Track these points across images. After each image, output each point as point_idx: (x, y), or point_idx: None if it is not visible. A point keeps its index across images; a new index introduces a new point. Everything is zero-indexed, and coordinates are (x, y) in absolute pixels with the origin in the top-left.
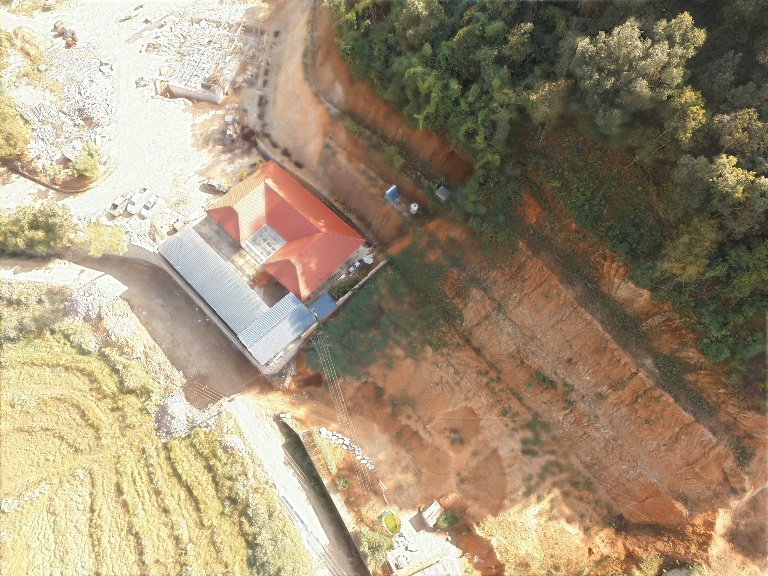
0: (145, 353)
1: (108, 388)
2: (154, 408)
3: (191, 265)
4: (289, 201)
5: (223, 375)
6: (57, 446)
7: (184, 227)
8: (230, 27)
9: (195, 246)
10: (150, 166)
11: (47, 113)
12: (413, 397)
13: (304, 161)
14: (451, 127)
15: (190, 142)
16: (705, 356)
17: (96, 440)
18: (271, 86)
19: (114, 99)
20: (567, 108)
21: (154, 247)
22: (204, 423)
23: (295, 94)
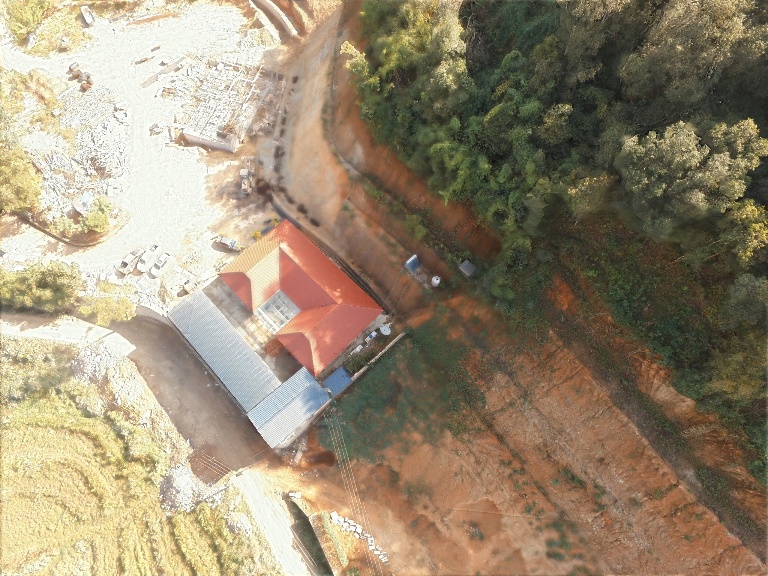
0: (151, 419)
1: (113, 455)
2: (159, 479)
3: (201, 333)
4: (304, 268)
5: (231, 446)
6: (59, 514)
7: (195, 291)
8: (248, 70)
9: (205, 312)
10: (162, 220)
11: (59, 161)
12: (430, 485)
13: (321, 219)
14: (478, 203)
15: (203, 195)
16: (756, 479)
17: (99, 510)
18: (288, 137)
19: (127, 147)
20: (608, 201)
21: (163, 309)
22: (210, 498)
23: (313, 151)
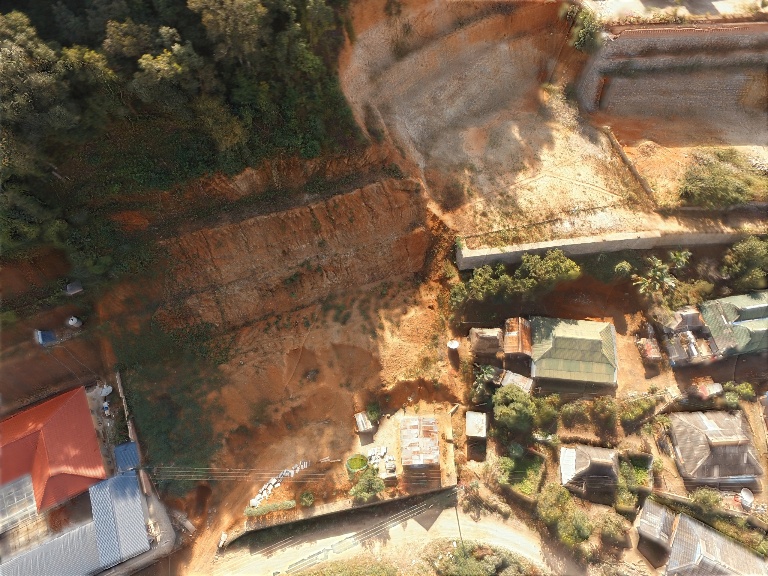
0: None
1: None
2: None
3: None
4: None
5: None
6: None
7: None
8: None
9: None
10: None
11: None
12: (260, 399)
13: None
14: (2, 248)
15: None
16: (314, 158)
17: None
18: None
19: None
20: (41, 142)
21: None
22: None
23: None
